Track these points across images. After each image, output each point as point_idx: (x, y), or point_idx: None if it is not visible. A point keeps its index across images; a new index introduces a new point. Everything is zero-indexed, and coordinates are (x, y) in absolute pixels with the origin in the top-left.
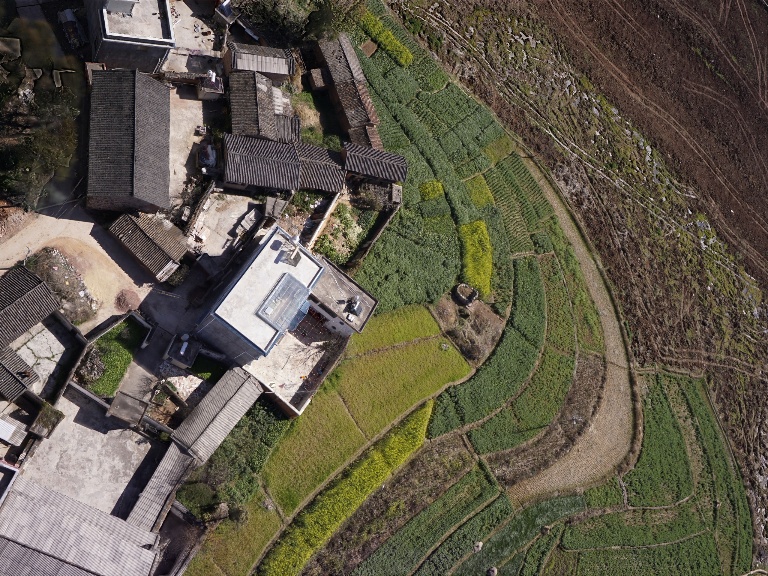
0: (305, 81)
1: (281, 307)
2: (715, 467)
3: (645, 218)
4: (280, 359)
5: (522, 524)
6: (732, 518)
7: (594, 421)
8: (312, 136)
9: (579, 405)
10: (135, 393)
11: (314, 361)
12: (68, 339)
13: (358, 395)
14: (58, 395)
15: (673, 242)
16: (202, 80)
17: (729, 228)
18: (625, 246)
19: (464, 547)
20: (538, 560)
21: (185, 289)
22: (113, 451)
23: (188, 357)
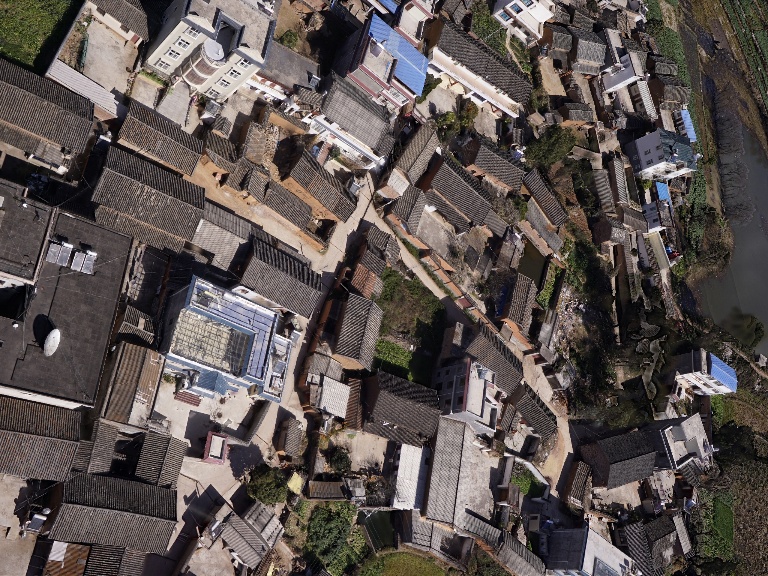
0: (677, 575)
1: (605, 575)
2: None
3: None
4: None
5: None
6: None
7: None
8: None
9: None
10: None
11: None
12: (524, 453)
13: None
14: None
15: None
16: (655, 498)
17: None
18: None
19: None
20: None
21: (563, 519)
22: (483, 495)
23: (543, 528)
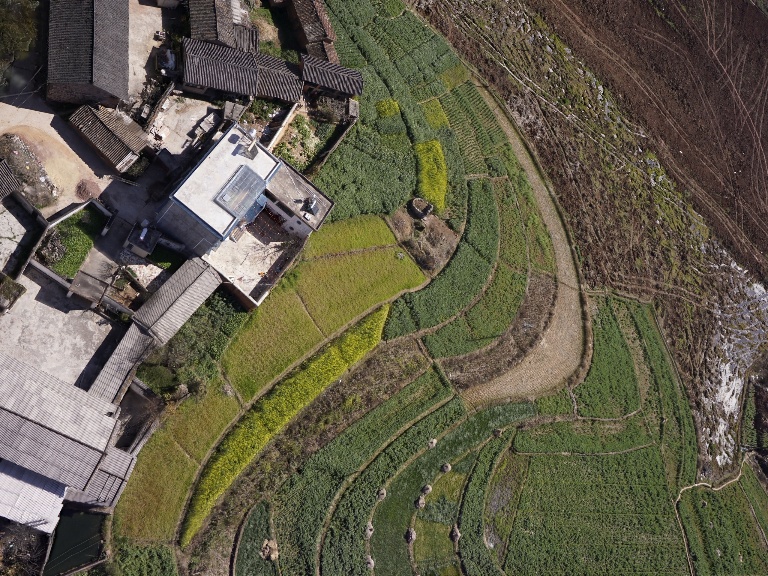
0: None
1: (238, 196)
2: (662, 386)
3: (597, 152)
4: (239, 255)
5: (475, 426)
6: (678, 434)
7: (545, 336)
8: (270, 50)
9: (531, 320)
10: (96, 277)
11: (272, 260)
12: (29, 222)
13: (315, 295)
14: (19, 271)
15: (624, 177)
16: None
17: (678, 168)
18: (577, 177)
19: (419, 442)
20: (490, 460)
21: (145, 183)
22: (74, 330)
23: (148, 244)
